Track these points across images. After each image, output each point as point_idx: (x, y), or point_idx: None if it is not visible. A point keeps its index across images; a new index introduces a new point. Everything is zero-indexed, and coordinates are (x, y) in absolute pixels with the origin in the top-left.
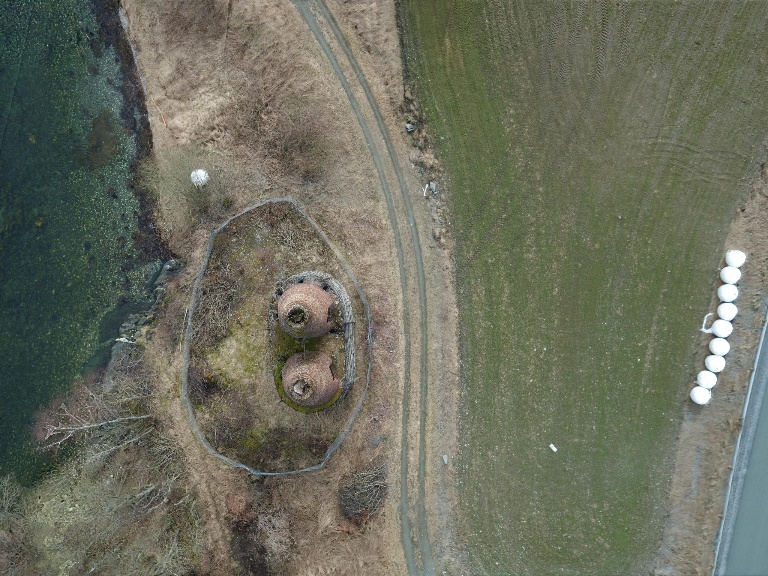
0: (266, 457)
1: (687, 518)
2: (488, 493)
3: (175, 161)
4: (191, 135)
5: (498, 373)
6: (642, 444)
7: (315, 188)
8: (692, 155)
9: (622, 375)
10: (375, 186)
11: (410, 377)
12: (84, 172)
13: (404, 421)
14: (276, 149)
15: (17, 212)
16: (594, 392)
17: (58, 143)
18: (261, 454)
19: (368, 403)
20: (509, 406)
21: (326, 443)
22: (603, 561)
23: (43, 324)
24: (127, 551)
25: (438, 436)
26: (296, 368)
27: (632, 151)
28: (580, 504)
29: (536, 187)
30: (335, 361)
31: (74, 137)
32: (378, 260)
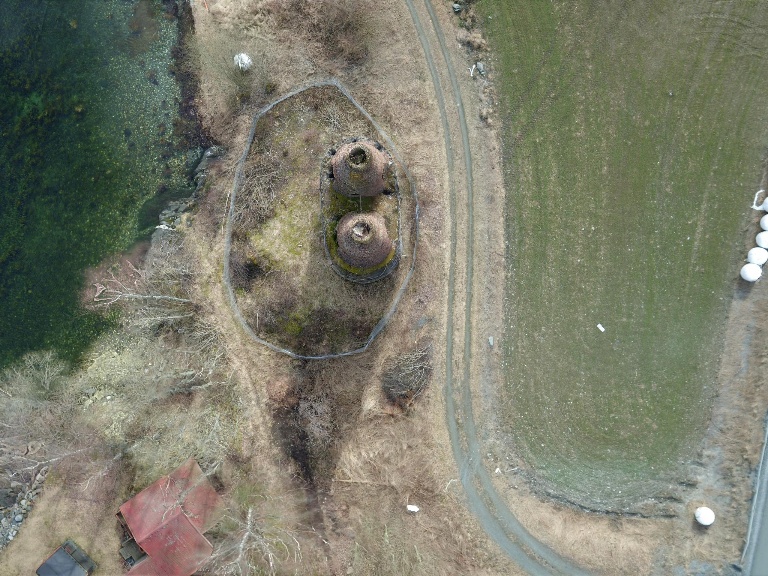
0: (308, 341)
1: (736, 397)
2: (534, 374)
3: (217, 46)
4: (234, 20)
5: (545, 253)
6: (691, 323)
7: (360, 71)
8: (744, 30)
9: (671, 253)
10: (422, 66)
11: (456, 258)
12: (125, 58)
13: (449, 302)
14: (320, 33)
15: (57, 97)
16: (643, 271)
17: (99, 29)
18: (303, 338)
19: (413, 283)
20: (556, 286)
21: (370, 325)
22: (650, 442)
23: (82, 212)
24: (166, 437)
25: (484, 318)
26: (354, 216)
27: (683, 27)
28: (628, 384)
29: (585, 65)
30: (388, 221)
31: (115, 23)
32: (424, 140)
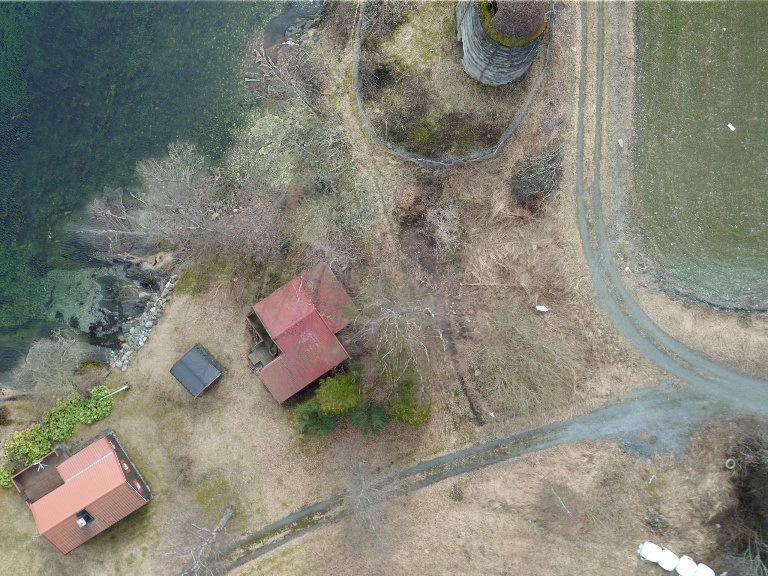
0: (437, 149)
1: None
2: (664, 175)
3: None
4: None
5: (676, 55)
6: None
7: None
8: None
9: None
10: None
11: (587, 61)
12: None
13: (580, 104)
14: None
15: None
16: None
17: None
18: (432, 146)
19: (545, 85)
20: (686, 88)
21: (500, 129)
22: None
23: (208, 29)
24: (294, 246)
25: (613, 121)
26: None
27: None
28: (758, 182)
29: None
30: None
31: None
32: None
